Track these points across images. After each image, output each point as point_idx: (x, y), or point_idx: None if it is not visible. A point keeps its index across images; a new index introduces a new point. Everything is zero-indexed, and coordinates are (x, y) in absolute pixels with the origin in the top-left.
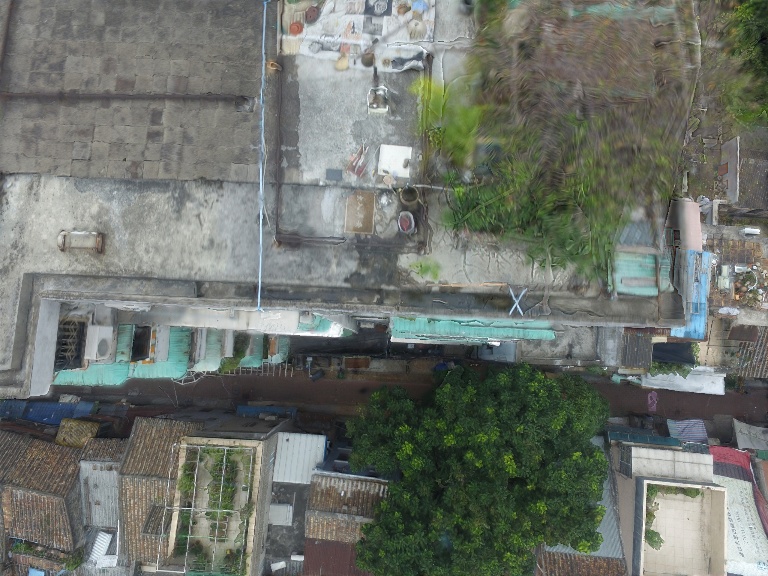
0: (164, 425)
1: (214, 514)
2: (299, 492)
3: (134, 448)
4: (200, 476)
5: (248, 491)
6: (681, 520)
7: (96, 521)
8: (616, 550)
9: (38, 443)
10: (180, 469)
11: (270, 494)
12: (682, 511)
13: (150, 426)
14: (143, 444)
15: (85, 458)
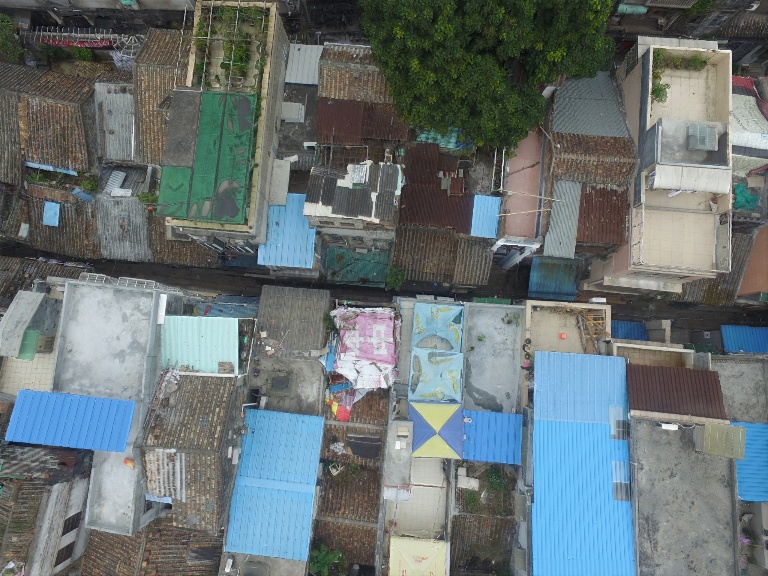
0: (177, 34)
1: (229, 66)
2: (311, 95)
3: (148, 48)
4: (214, 47)
5: (263, 21)
6: (686, 95)
7: (110, 153)
8: (623, 133)
9: (53, 73)
10: (195, 27)
11: (282, 93)
12: (687, 87)
13: (164, 34)
14: (157, 46)
15: (99, 82)
